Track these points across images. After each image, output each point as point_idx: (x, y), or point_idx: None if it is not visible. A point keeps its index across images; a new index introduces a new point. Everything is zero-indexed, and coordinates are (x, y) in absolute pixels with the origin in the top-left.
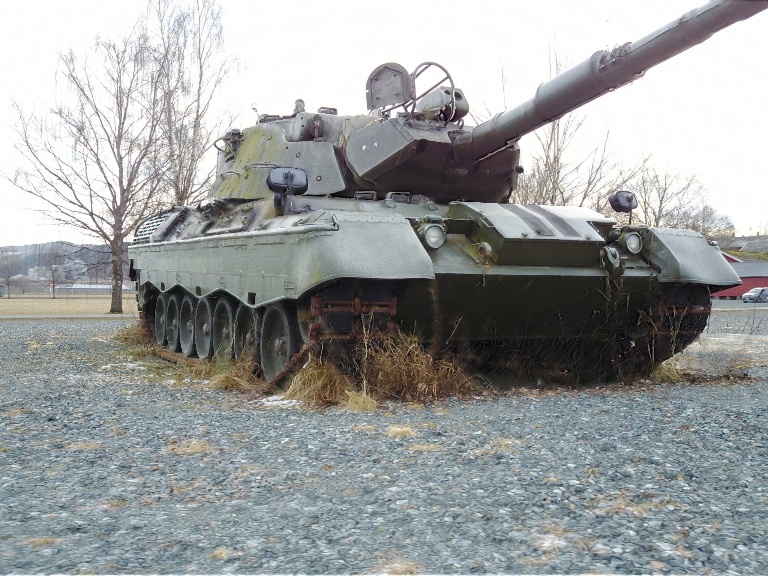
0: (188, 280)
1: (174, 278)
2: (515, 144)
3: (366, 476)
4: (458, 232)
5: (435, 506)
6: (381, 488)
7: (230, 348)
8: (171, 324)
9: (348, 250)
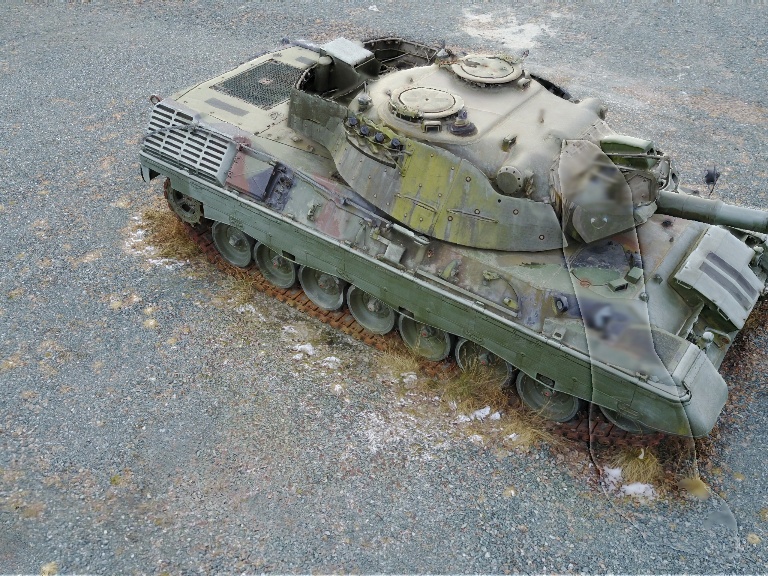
0: (377, 292)
1: (332, 270)
2: None
3: None
4: None
5: None
6: None
7: (446, 354)
8: (261, 256)
9: (702, 411)
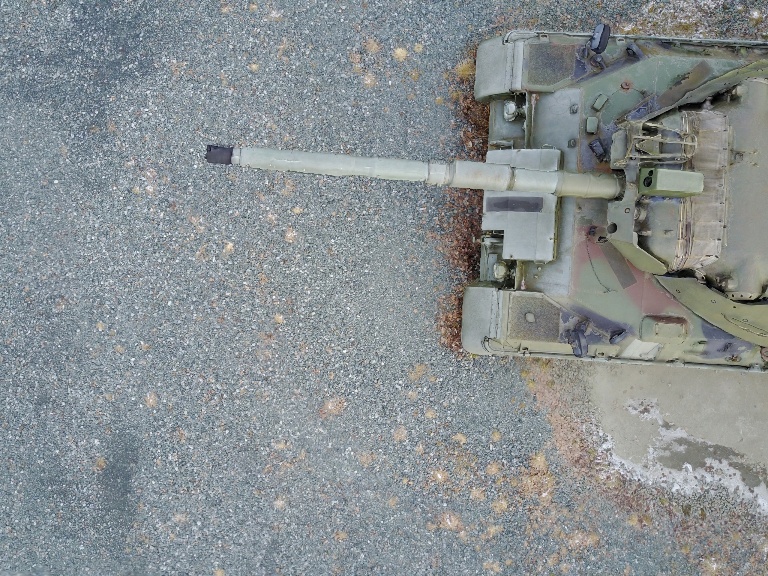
0: None
1: None
2: (612, 234)
3: (343, 6)
4: (529, 143)
5: (310, 8)
6: (330, 4)
7: None
8: None
9: None
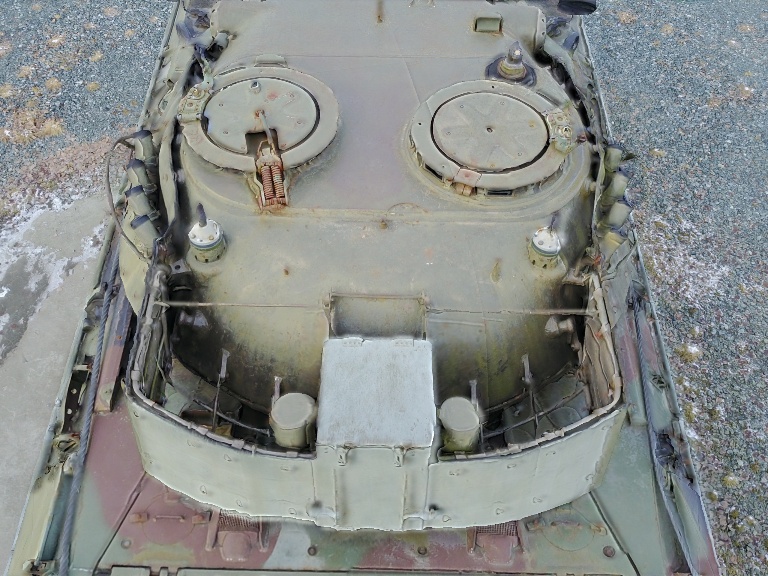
0: None
1: None
2: None
3: None
4: None
5: None
6: None
7: None
8: None
9: None
